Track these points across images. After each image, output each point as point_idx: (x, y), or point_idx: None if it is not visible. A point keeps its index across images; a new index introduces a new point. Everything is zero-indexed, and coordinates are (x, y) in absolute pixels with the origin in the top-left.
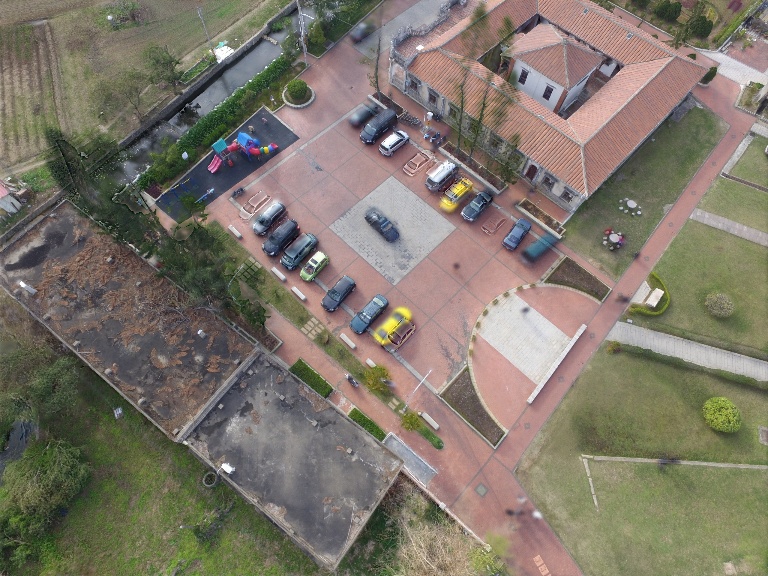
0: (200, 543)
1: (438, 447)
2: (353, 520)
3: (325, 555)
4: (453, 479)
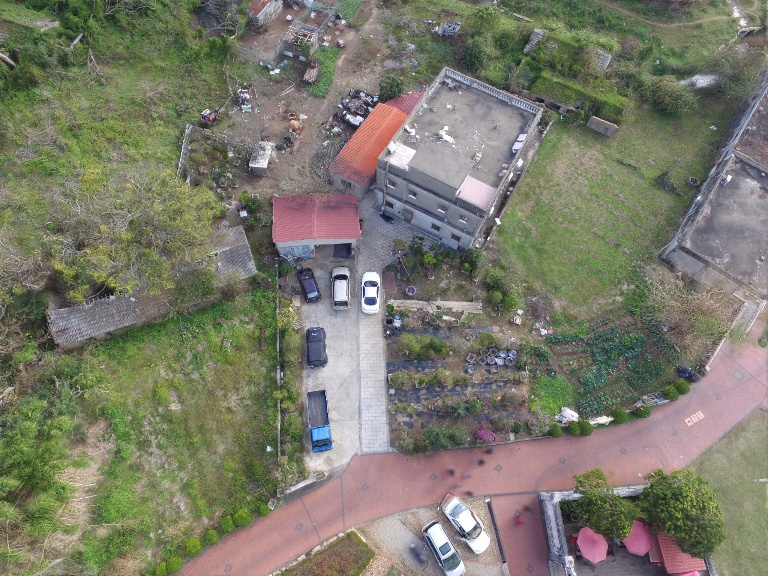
0: (654, 179)
1: (761, 342)
2: (717, 259)
3: (689, 241)
4: (739, 352)
